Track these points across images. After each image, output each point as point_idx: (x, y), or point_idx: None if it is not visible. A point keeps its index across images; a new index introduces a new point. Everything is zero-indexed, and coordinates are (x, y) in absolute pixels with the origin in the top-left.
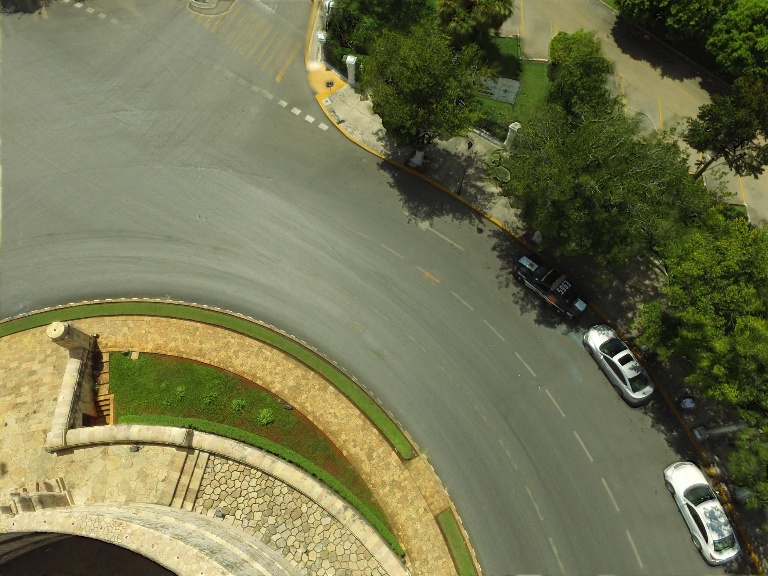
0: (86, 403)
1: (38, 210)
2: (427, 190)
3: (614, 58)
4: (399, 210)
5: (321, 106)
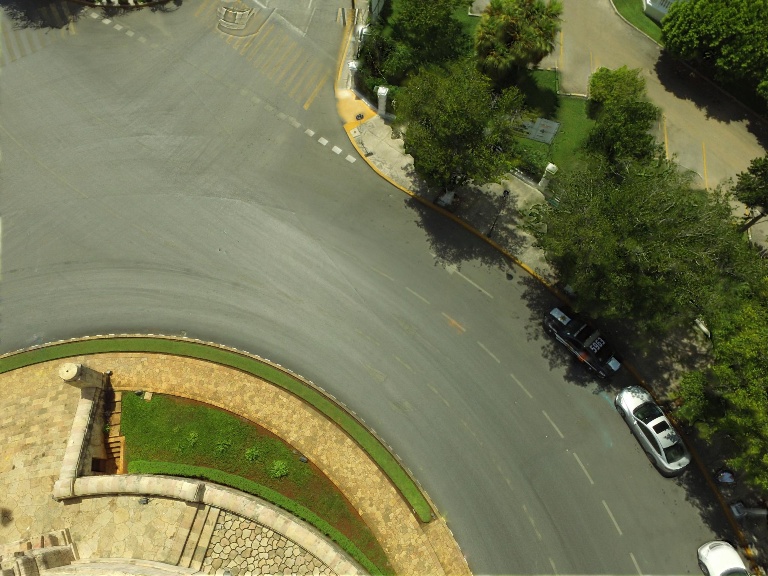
0: (96, 446)
1: (56, 236)
2: (456, 231)
3: (657, 96)
4: (426, 251)
5: (349, 137)
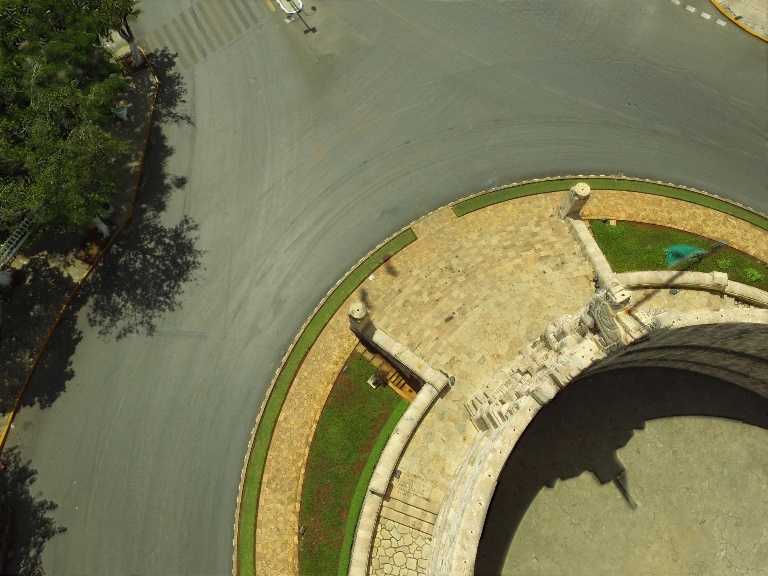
0: None
1: (478, 99)
2: None
3: None
4: None
5: (714, 3)
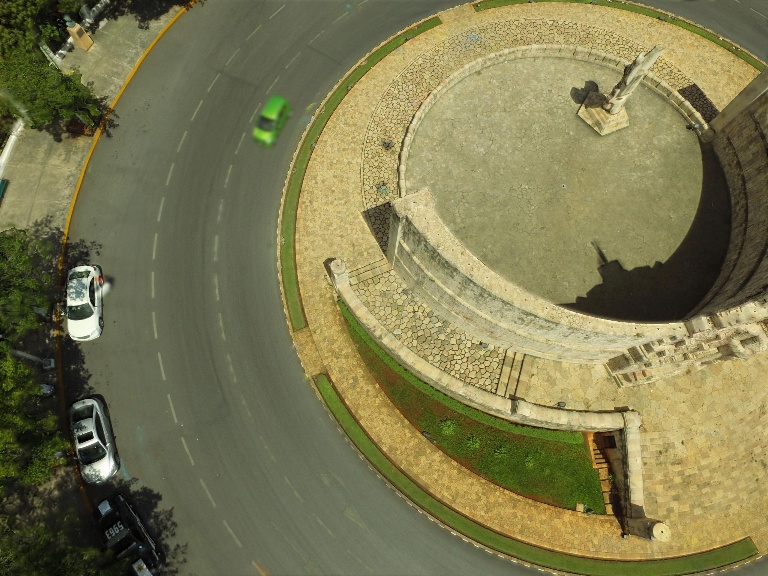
0: (616, 459)
1: None
2: None
3: None
4: None
5: None
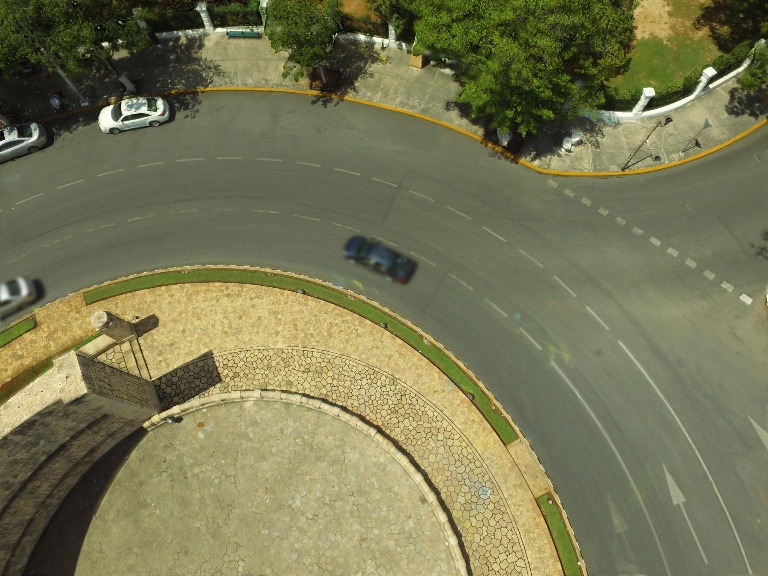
0: None
1: None
2: None
3: None
4: None
5: None
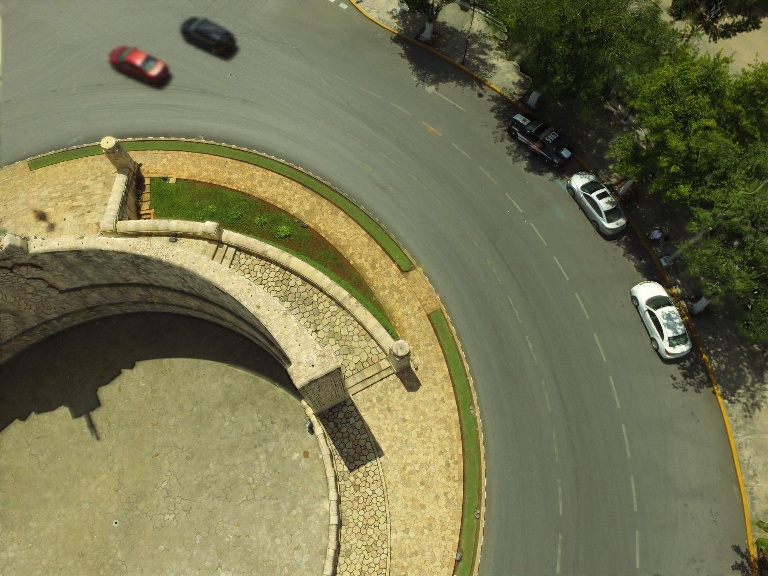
0: (131, 211)
1: (90, 65)
2: (434, 61)
3: None
4: (408, 76)
5: None
